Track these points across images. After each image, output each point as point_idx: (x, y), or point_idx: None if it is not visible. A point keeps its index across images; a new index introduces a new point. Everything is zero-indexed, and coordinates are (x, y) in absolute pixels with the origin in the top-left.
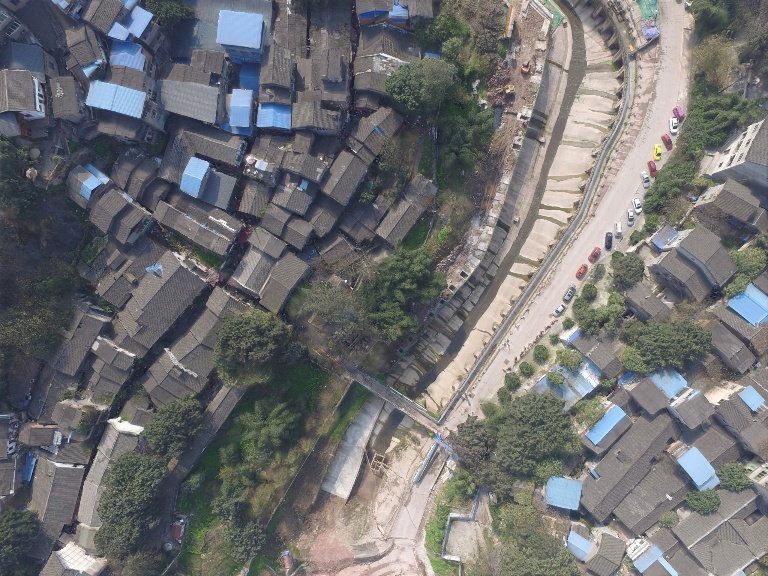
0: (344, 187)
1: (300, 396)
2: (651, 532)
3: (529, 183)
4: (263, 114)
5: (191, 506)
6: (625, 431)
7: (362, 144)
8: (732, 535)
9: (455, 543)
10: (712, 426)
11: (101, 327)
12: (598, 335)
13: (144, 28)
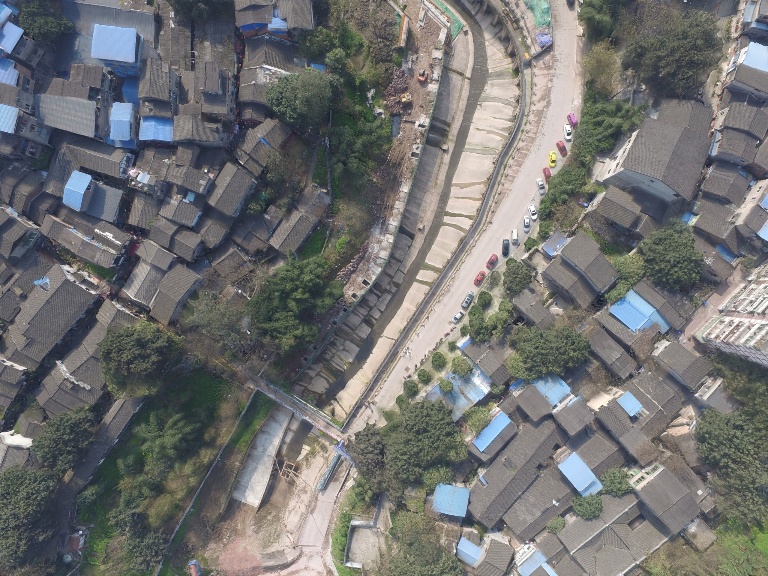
0: (229, 199)
1: (203, 406)
2: (540, 537)
3: (433, 190)
4: (145, 127)
5: (92, 517)
6: (512, 438)
7: (249, 155)
8: (615, 540)
9: (358, 550)
10: (597, 431)
11: None
12: (490, 342)
13: (15, 44)
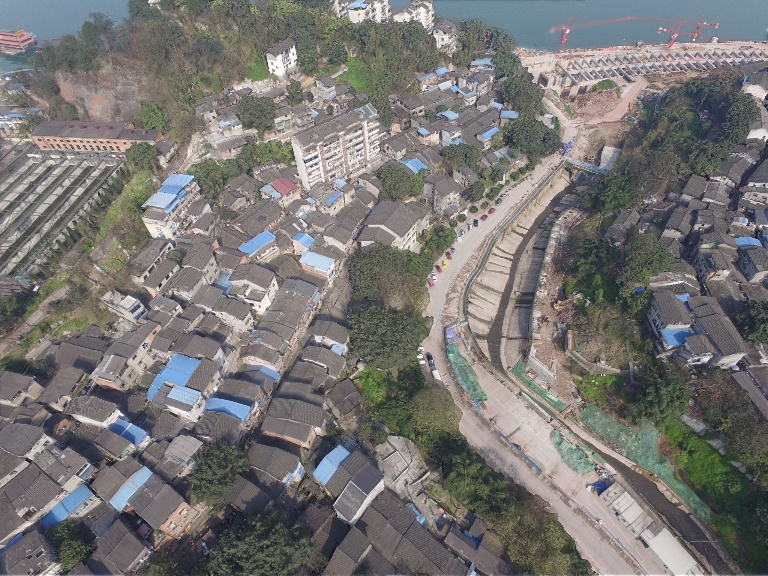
0: None
1: None
2: (463, 107)
3: (523, 271)
4: None
5: None
6: None
7: None
8: None
9: (547, 121)
10: None
11: None
12: None
13: None
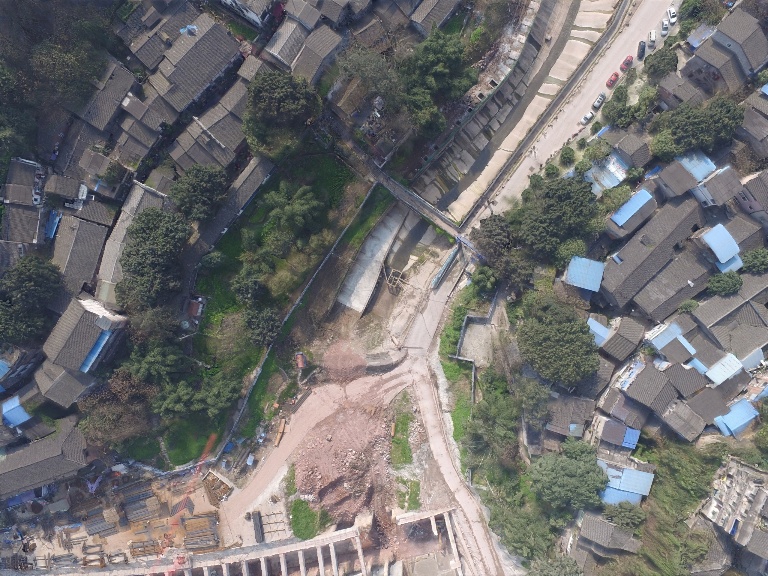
0: None
1: None
2: (670, 320)
3: (563, 2)
4: None
5: (209, 289)
6: (650, 217)
7: None
8: (752, 318)
9: (470, 346)
10: (738, 214)
11: (132, 83)
12: (627, 131)
13: None
